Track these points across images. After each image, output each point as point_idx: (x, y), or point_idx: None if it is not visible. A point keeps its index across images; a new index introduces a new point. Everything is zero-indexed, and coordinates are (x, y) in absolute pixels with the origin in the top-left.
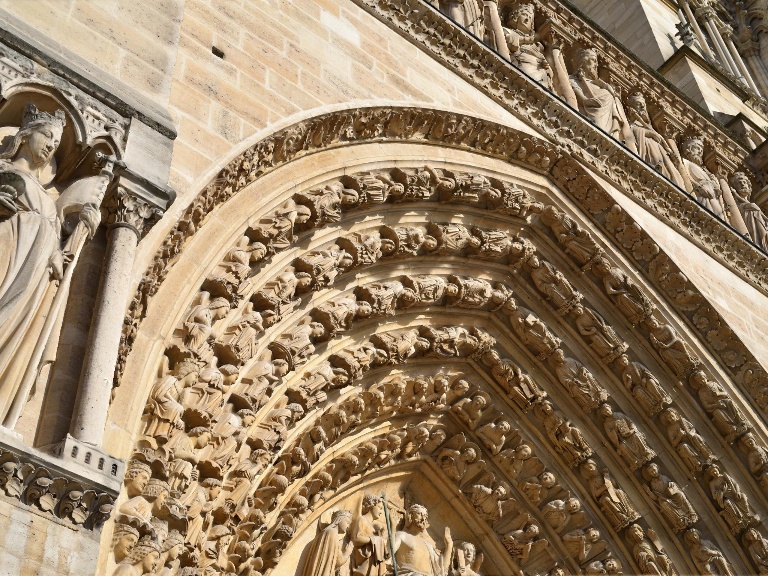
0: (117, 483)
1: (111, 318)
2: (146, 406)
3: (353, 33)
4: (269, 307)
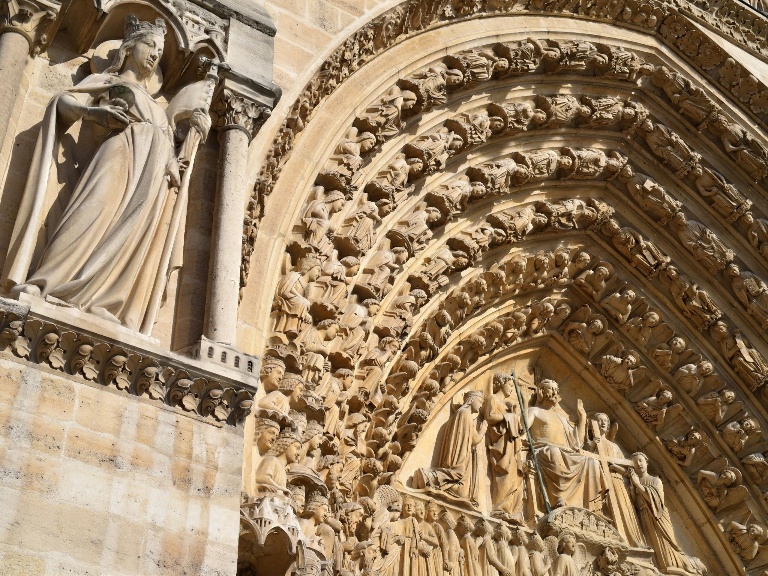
0: (254, 379)
1: (231, 220)
2: (273, 303)
3: None
4: (383, 196)
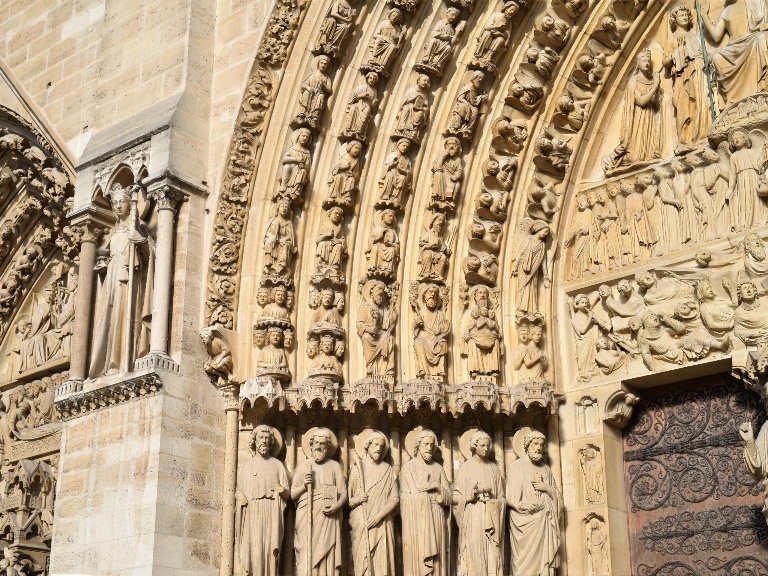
0: None
1: None
2: None
3: None
4: None
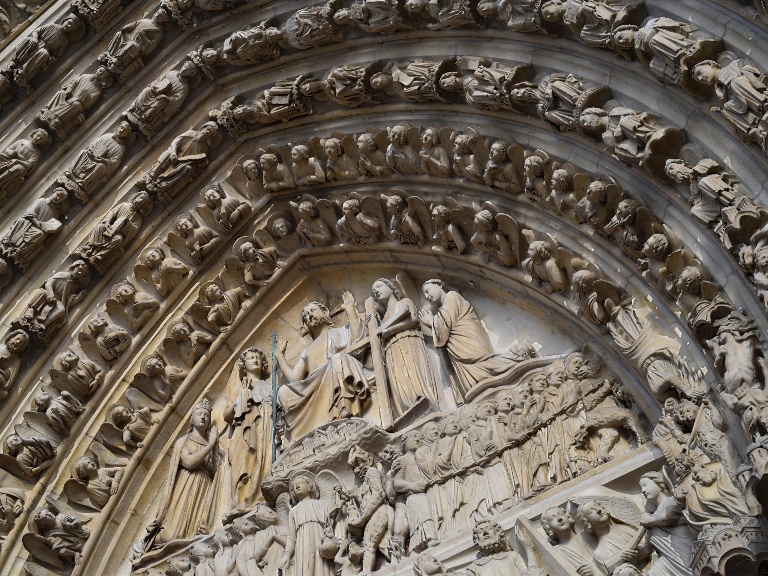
0: None
1: None
2: None
3: None
4: None
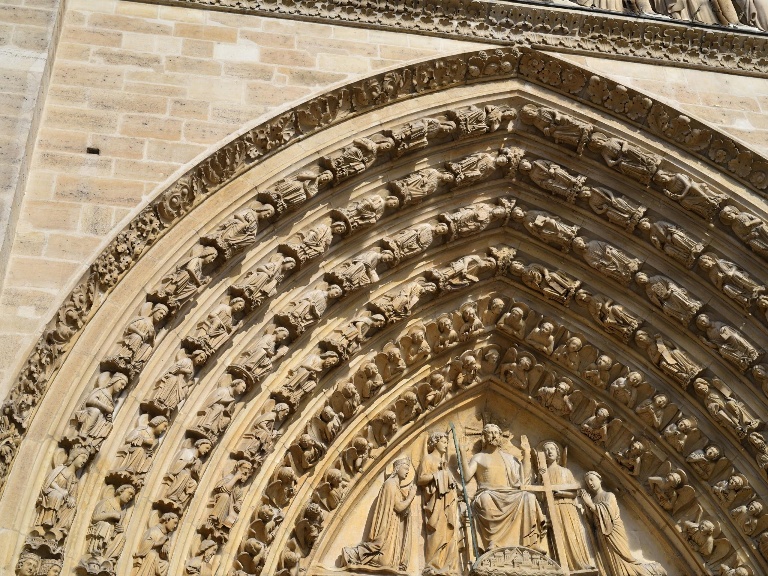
0: None
1: None
2: (37, 501)
3: (252, 51)
4: (199, 347)
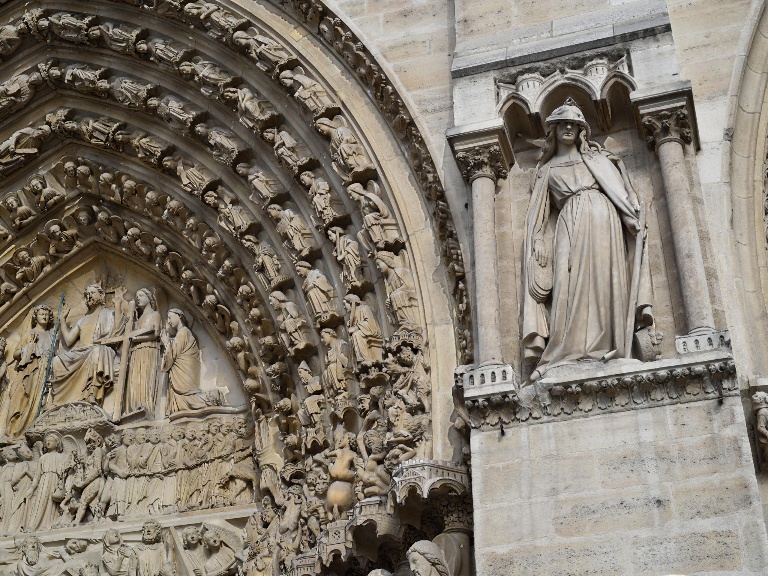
0: None
1: None
2: None
3: None
4: None
